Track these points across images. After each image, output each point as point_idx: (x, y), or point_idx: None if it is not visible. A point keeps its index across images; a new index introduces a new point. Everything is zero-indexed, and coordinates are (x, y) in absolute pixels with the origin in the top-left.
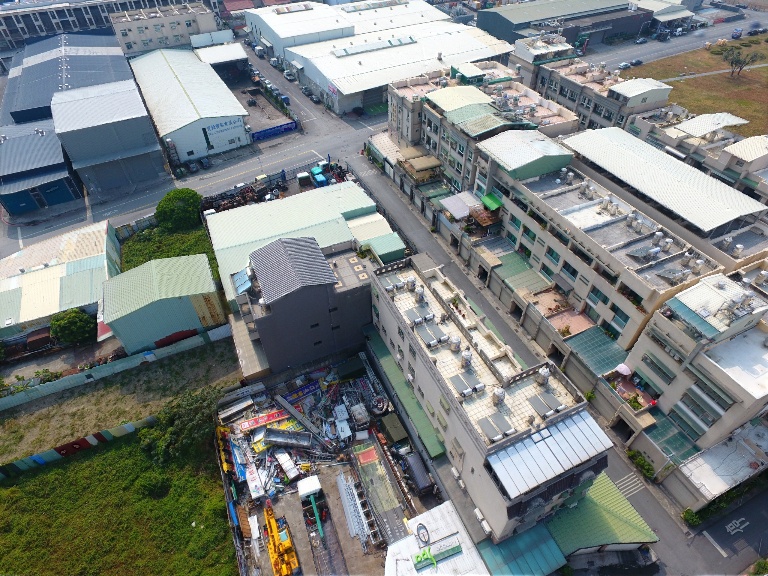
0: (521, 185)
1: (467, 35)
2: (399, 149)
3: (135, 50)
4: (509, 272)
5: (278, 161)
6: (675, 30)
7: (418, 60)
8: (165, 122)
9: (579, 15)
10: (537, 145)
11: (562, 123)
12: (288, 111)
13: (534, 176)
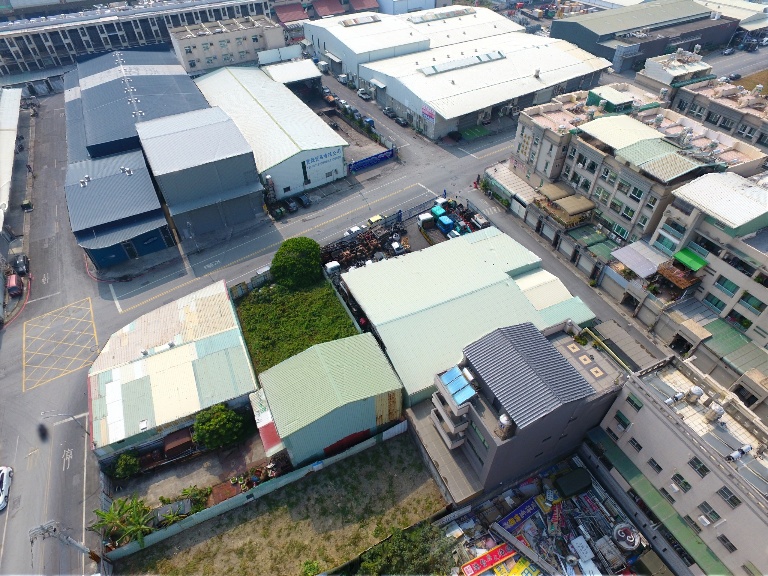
0: (746, 245)
1: (556, 49)
2: (529, 185)
3: (198, 68)
4: (725, 347)
5: (384, 197)
6: (761, 39)
7: (514, 78)
8: (259, 155)
9: (663, 25)
10: (752, 194)
11: (751, 161)
12: (379, 137)
13: (752, 231)
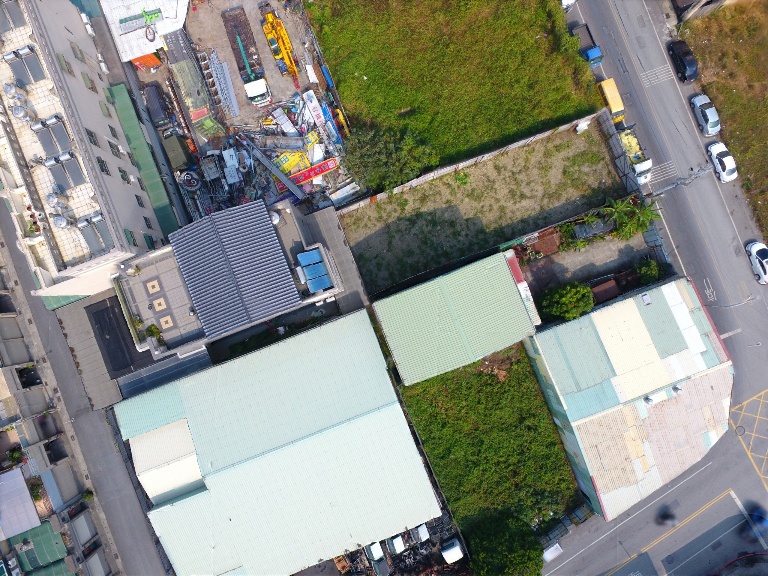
0: None
1: None
2: None
3: None
4: None
5: None
6: None
7: None
8: None
9: None
10: None
11: None
12: None
13: None
